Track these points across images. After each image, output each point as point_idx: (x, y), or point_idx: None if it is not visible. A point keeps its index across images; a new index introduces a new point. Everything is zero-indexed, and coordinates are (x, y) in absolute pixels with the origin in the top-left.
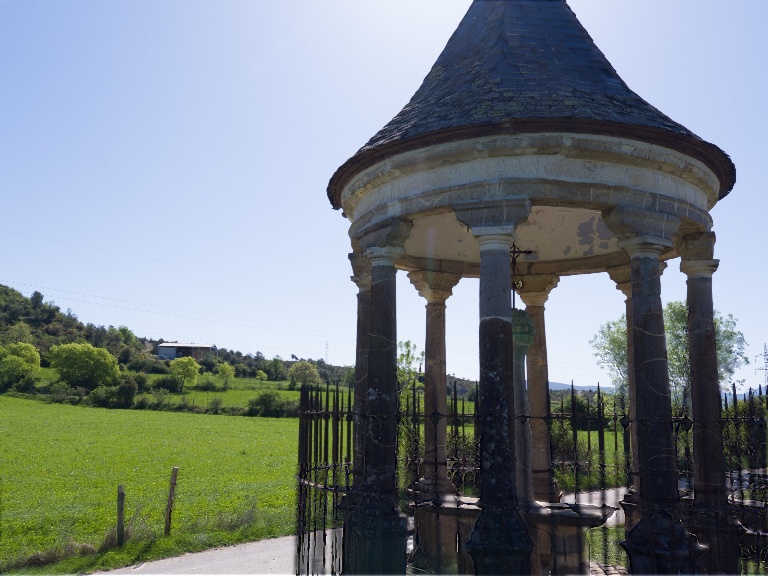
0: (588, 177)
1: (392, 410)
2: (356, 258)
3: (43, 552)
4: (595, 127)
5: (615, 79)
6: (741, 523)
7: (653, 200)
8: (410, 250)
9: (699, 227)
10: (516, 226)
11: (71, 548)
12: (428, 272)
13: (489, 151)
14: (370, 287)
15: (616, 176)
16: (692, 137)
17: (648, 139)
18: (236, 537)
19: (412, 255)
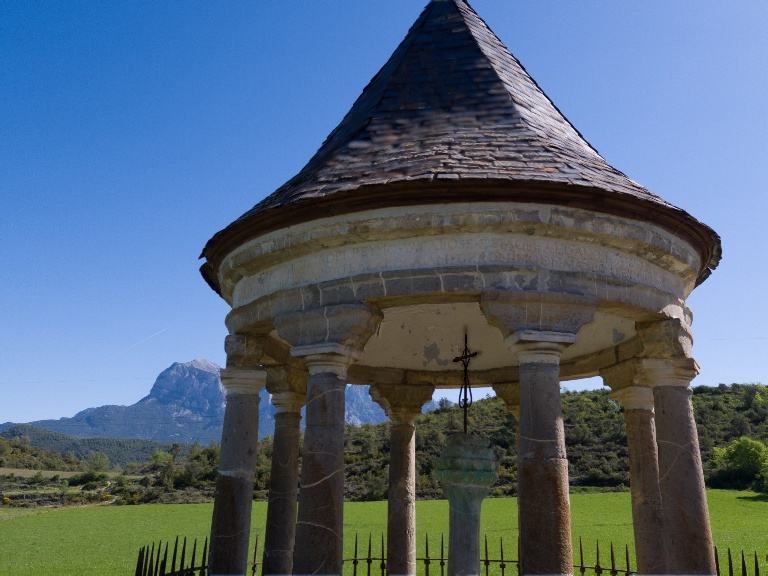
0: (259, 292)
1: (272, 568)
2: (372, 393)
3: None
4: (236, 239)
5: (367, 134)
6: None
7: (314, 294)
8: (476, 364)
9: (448, 293)
10: (241, 365)
11: None
12: (501, 385)
13: (226, 293)
14: (395, 421)
15: (280, 280)
16: (310, 198)
17: (279, 225)
18: None
19: (479, 369)
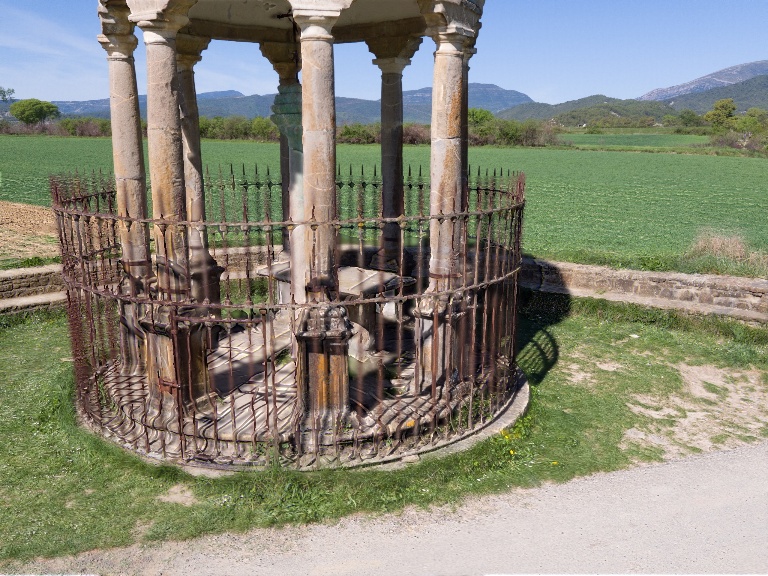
0: None
1: None
2: None
3: None
4: None
5: None
6: None
7: None
8: None
9: None
10: None
11: None
12: None
13: None
14: None
15: None
16: None
17: None
18: None
19: None
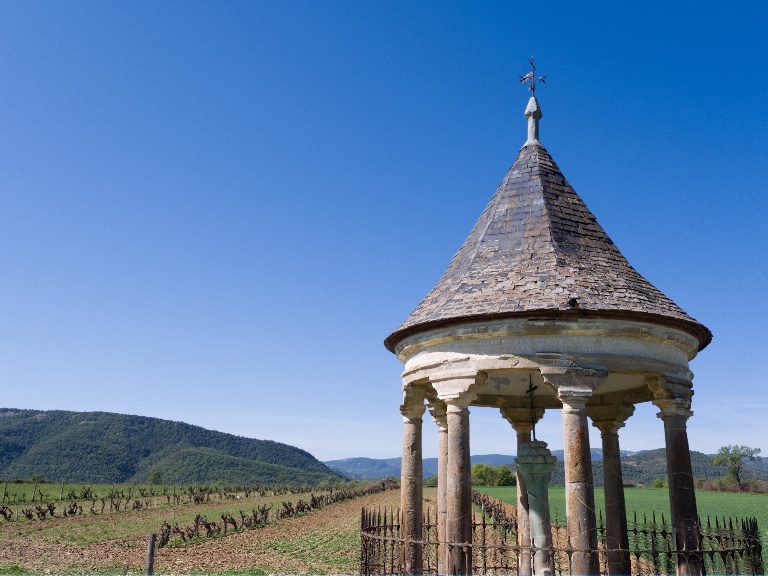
0: None
1: None
2: None
3: None
4: None
5: None
6: None
7: None
8: None
9: None
10: None
11: None
12: None
13: None
14: None
15: None
16: None
17: None
18: None
19: None
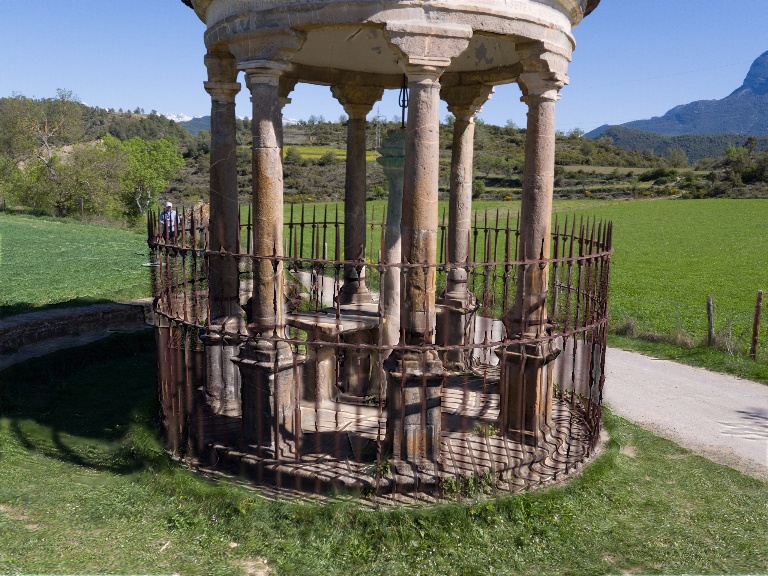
0: None
1: None
2: None
3: None
4: None
5: None
6: (254, 363)
7: None
8: None
9: None
10: None
11: (676, 338)
12: None
13: None
14: None
15: None
16: None
17: None
18: None
19: None
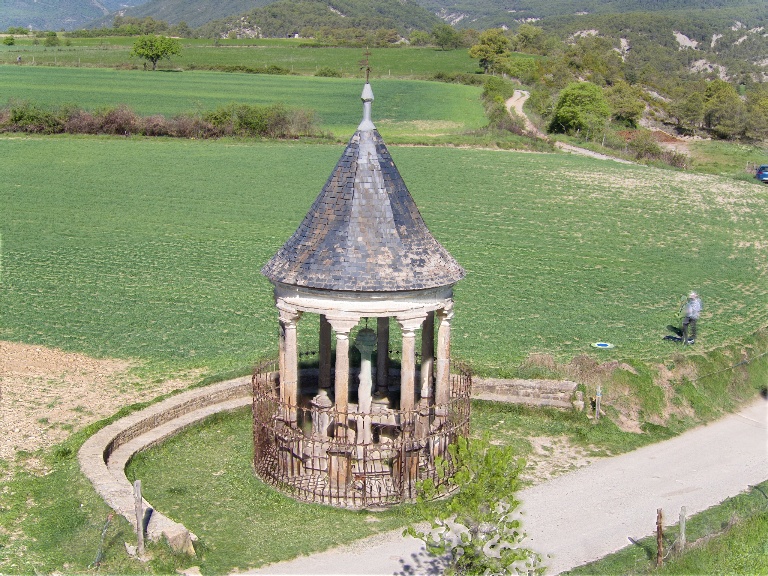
0: None
1: None
2: None
3: (716, 539)
4: None
5: None
6: None
7: None
8: None
9: None
10: None
11: None
12: None
13: None
14: None
15: None
16: None
17: None
18: (595, 567)
19: None
